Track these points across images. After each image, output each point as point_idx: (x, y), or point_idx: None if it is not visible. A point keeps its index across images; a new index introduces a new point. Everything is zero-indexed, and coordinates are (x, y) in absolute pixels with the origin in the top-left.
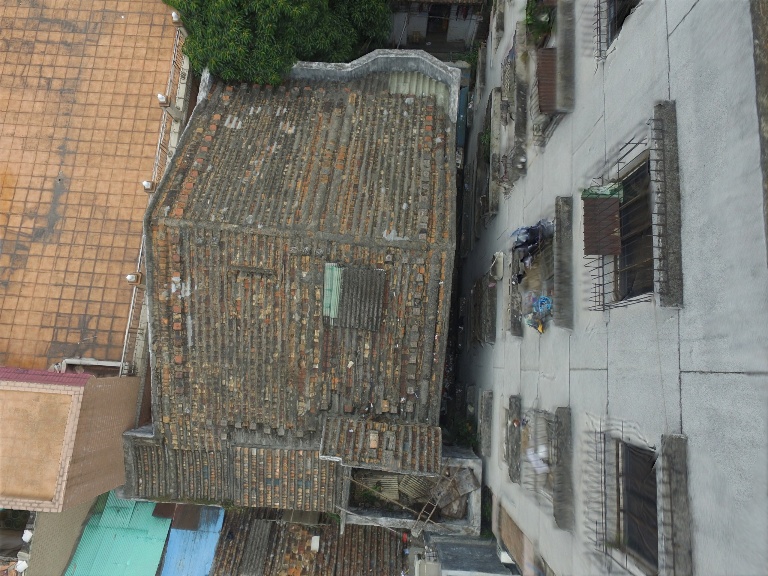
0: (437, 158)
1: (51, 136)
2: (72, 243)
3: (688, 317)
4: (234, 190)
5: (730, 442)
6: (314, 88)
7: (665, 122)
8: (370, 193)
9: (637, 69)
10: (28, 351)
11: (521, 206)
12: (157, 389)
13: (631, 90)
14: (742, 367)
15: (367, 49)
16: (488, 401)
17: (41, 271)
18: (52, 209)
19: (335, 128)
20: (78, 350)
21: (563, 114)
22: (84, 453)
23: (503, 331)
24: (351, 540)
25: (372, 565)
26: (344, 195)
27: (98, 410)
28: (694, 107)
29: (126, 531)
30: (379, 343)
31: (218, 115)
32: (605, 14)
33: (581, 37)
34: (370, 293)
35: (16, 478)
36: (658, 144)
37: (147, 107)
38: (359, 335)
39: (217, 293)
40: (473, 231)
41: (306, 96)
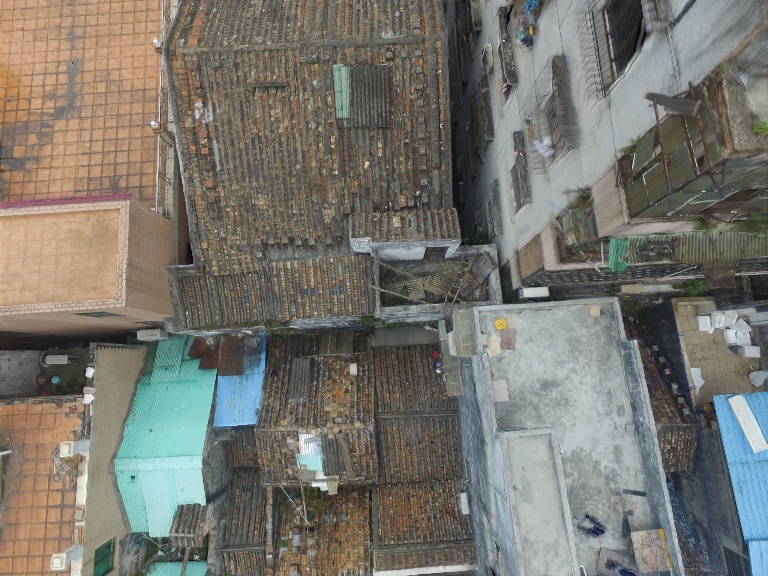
0: None
1: (59, 26)
2: (93, 116)
3: None
4: (240, 22)
5: None
6: None
7: None
8: (364, 9)
9: None
10: None
11: None
12: (193, 217)
13: None
14: None
15: None
16: (495, 188)
17: (67, 144)
18: (69, 89)
19: None
20: None
21: None
22: (137, 263)
23: (500, 110)
24: (386, 363)
25: (408, 379)
26: (341, 13)
27: (143, 230)
28: None
29: (177, 383)
30: (390, 140)
31: None
32: None
33: None
34: (377, 89)
35: (79, 286)
36: None
37: None
38: (371, 135)
39: (238, 113)
40: (461, 85)
41: None
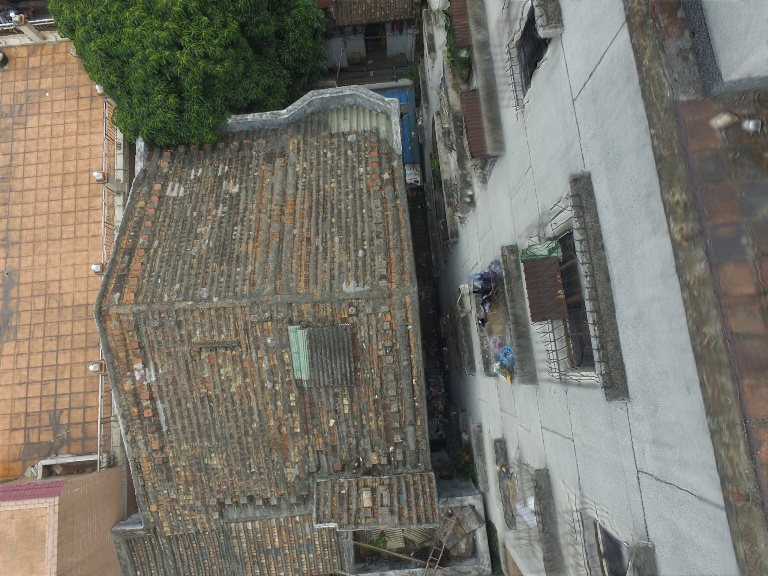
0: (387, 196)
1: None
2: (30, 337)
3: (636, 412)
4: (184, 264)
5: (694, 568)
6: (254, 139)
7: (583, 197)
8: (324, 245)
9: (552, 128)
10: (1, 457)
11: (476, 239)
12: (138, 479)
13: (550, 148)
14: (693, 488)
15: (306, 83)
16: (478, 435)
17: (2, 372)
18: (4, 305)
19: (280, 180)
20: (53, 448)
21: (496, 157)
22: (70, 564)
23: (480, 365)
24: None
25: None
26: (297, 251)
27: (79, 515)
28: (608, 185)
29: None
30: (357, 397)
31: (158, 185)
32: (516, 60)
33: (500, 78)
34: (339, 349)
35: None
36: (579, 222)
37: (86, 184)
38: (335, 392)
39: (183, 373)
40: (441, 252)
41: (246, 149)
